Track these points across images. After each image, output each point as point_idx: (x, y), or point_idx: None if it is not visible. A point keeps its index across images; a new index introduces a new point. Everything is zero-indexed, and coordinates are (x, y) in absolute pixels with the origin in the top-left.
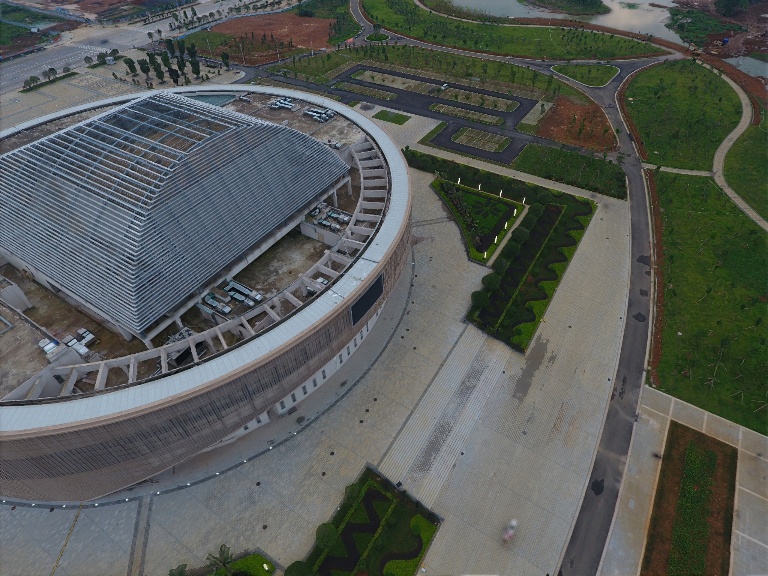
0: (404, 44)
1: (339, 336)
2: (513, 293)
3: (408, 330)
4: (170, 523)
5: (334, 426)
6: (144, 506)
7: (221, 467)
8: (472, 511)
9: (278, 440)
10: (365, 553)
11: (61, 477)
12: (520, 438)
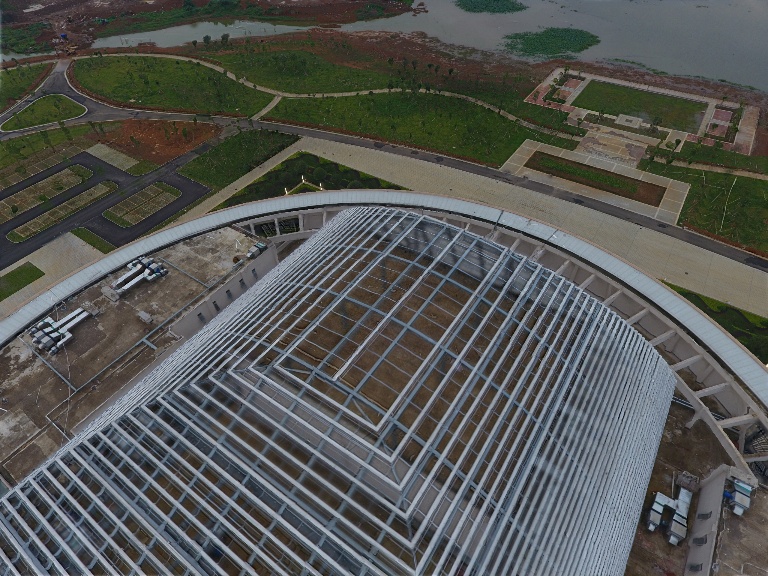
0: None
1: None
2: None
3: None
4: None
5: None
6: None
7: None
8: None
9: None
10: None
11: None
12: None
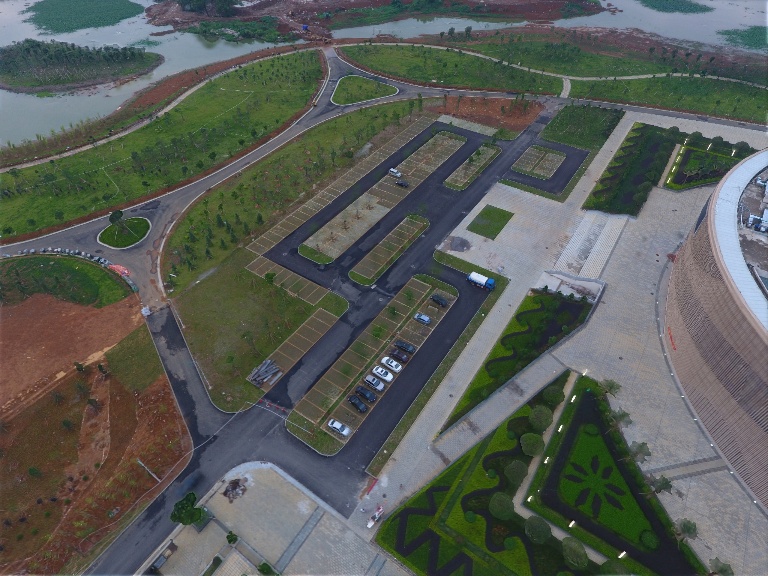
0: None
1: None
2: None
3: None
4: None
5: None
6: None
7: None
8: None
9: None
10: None
11: None
12: None
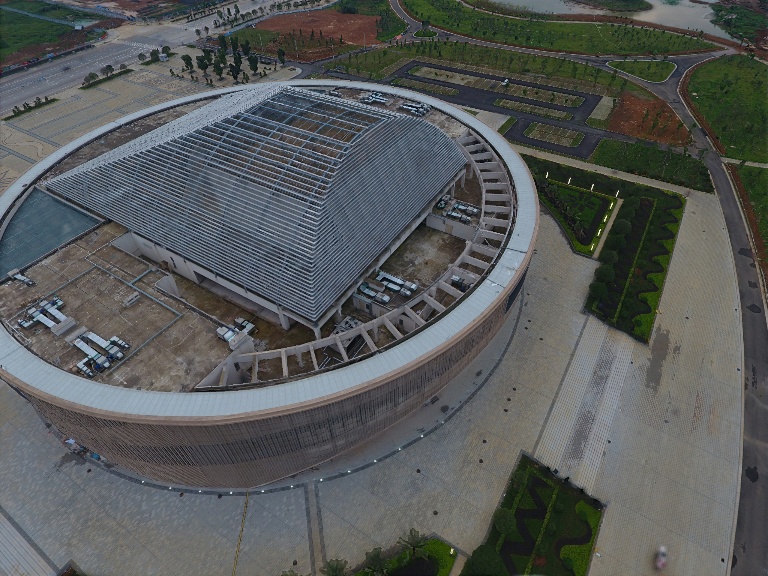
0: (454, 40)
1: (495, 325)
2: (624, 285)
3: (530, 321)
4: (340, 509)
5: (480, 415)
6: (310, 493)
7: (377, 455)
8: (632, 498)
9: (427, 428)
10: (539, 538)
11: (243, 463)
12: (663, 427)
